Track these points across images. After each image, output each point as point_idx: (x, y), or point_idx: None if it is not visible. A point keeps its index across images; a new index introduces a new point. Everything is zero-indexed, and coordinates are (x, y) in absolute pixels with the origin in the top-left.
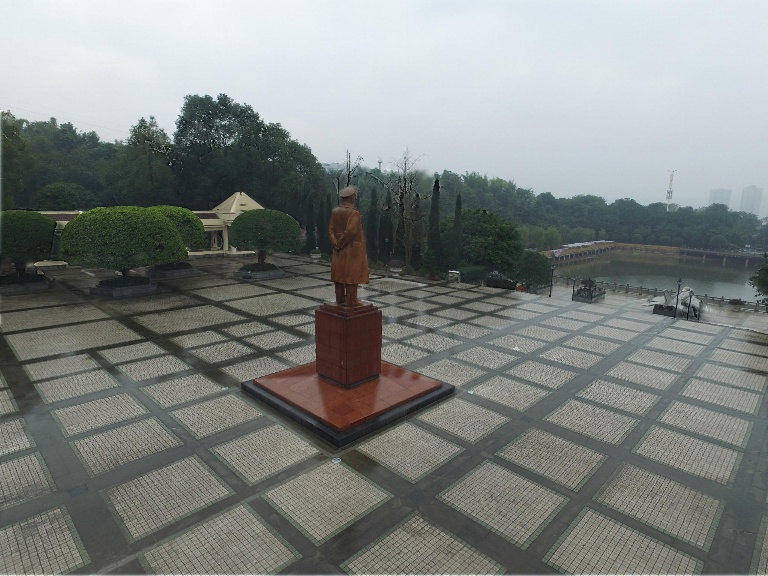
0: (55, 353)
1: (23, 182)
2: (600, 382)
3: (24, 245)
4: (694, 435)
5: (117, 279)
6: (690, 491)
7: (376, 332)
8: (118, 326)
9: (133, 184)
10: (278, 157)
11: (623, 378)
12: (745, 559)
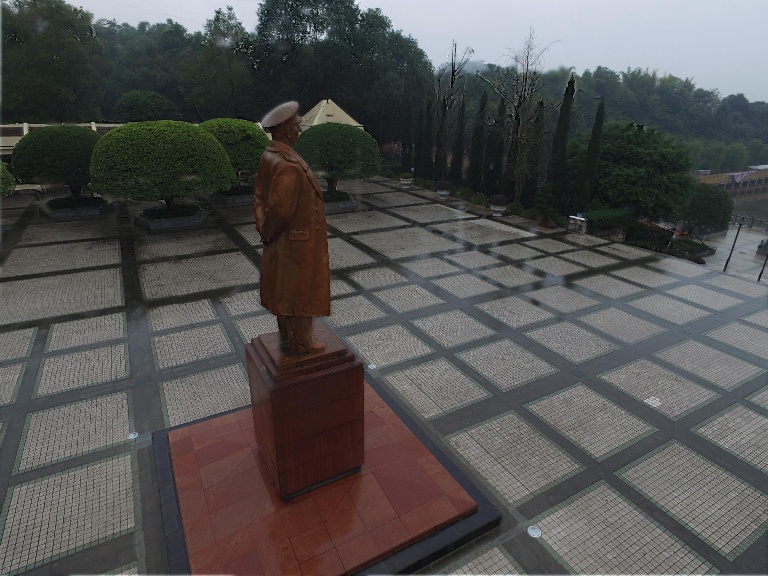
0: (6, 322)
1: (102, 90)
2: None
3: (64, 166)
4: None
5: (162, 208)
6: None
7: (349, 401)
8: (114, 280)
9: (210, 91)
10: None
11: None
12: None
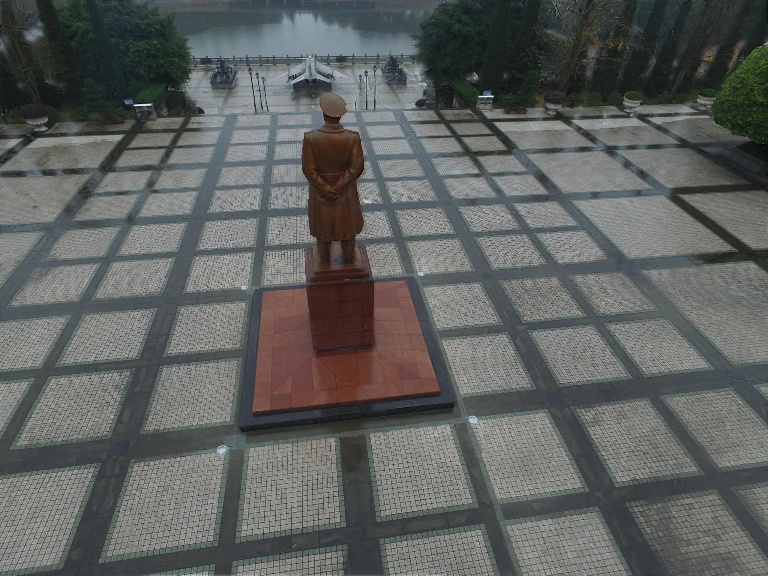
0: None
1: None
2: (463, 209)
3: None
4: (557, 230)
5: None
6: (608, 275)
7: None
8: None
9: None
10: None
11: (467, 197)
12: (668, 303)
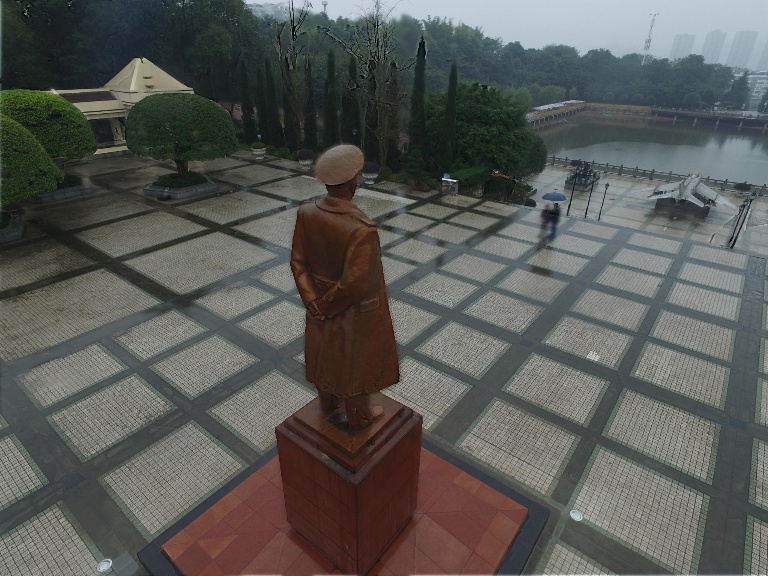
0: None
1: None
2: (765, 450)
3: None
4: None
5: None
6: None
7: (411, 458)
8: None
9: None
10: (189, 0)
11: None
12: None
